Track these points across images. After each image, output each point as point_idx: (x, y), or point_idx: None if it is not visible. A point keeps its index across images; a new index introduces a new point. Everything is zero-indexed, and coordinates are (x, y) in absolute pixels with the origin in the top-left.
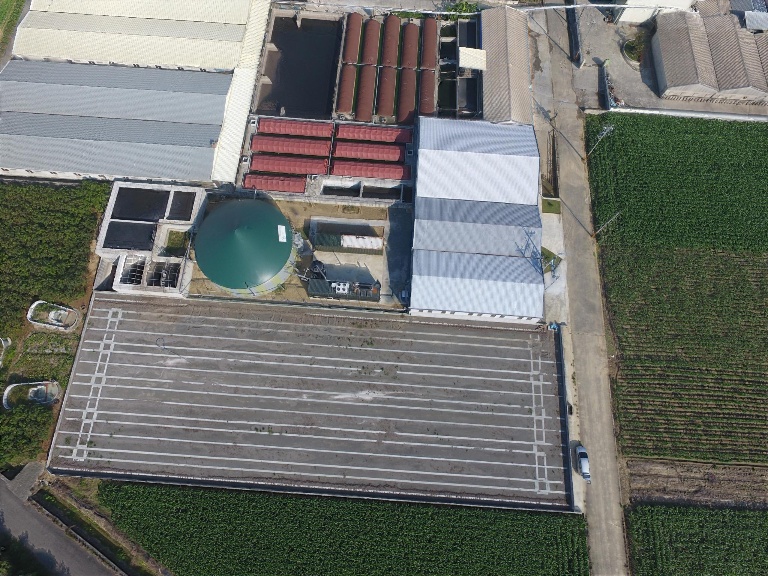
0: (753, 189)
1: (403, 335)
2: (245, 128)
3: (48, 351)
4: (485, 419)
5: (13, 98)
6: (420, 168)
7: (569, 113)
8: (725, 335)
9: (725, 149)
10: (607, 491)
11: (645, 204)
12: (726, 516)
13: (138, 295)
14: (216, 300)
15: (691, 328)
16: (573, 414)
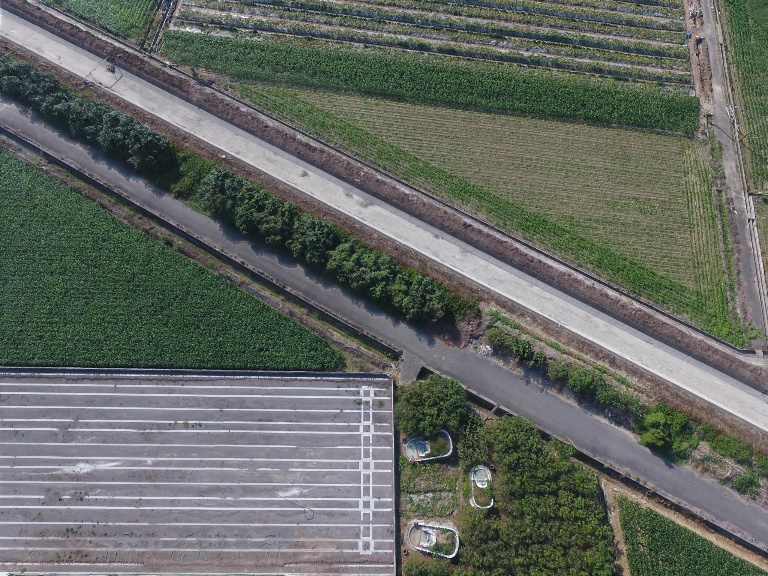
0: None
1: (28, 544)
2: None
3: (430, 495)
4: None
5: None
6: None
7: None
8: None
9: None
10: None
11: None
12: None
13: (344, 575)
14: (249, 575)
15: None
16: None
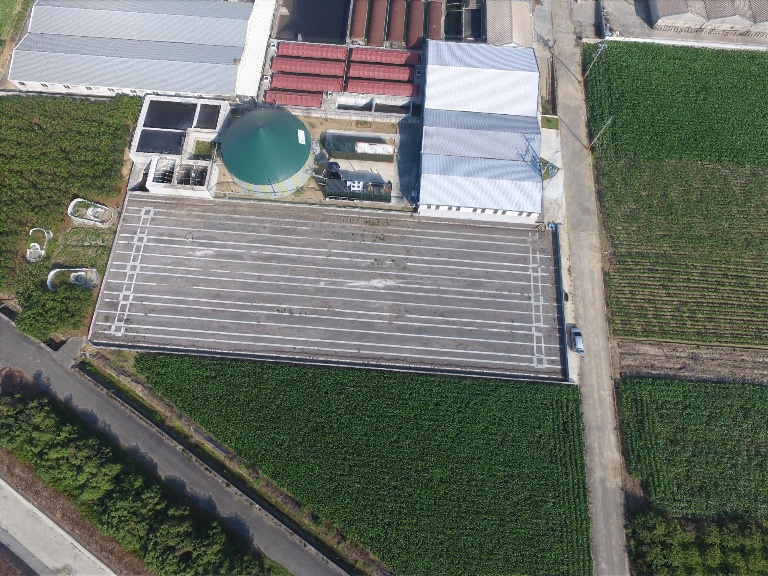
0: (738, 109)
1: (412, 232)
2: (266, 50)
3: (86, 244)
4: (488, 304)
5: (51, 22)
6: (428, 82)
7: (567, 42)
8: (710, 235)
9: (713, 74)
10: (599, 366)
11: (637, 121)
12: (708, 387)
13: (168, 196)
14: (240, 200)
15: (679, 229)
16: (569, 301)
